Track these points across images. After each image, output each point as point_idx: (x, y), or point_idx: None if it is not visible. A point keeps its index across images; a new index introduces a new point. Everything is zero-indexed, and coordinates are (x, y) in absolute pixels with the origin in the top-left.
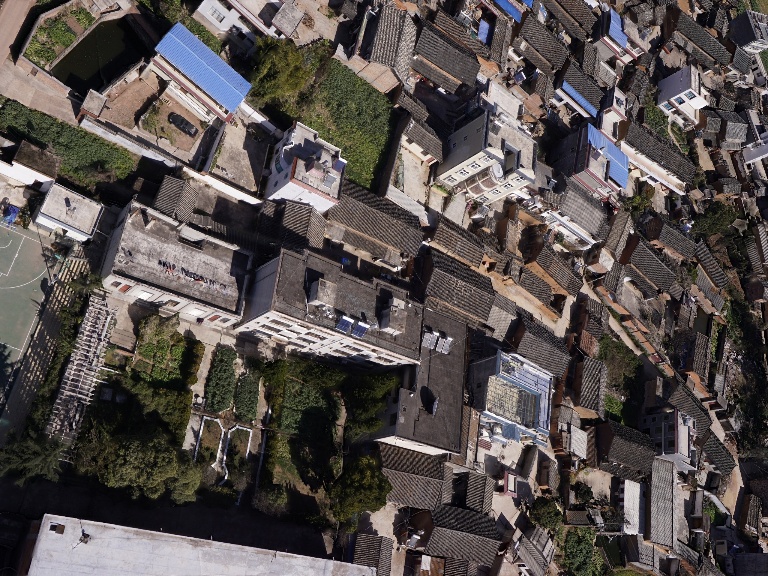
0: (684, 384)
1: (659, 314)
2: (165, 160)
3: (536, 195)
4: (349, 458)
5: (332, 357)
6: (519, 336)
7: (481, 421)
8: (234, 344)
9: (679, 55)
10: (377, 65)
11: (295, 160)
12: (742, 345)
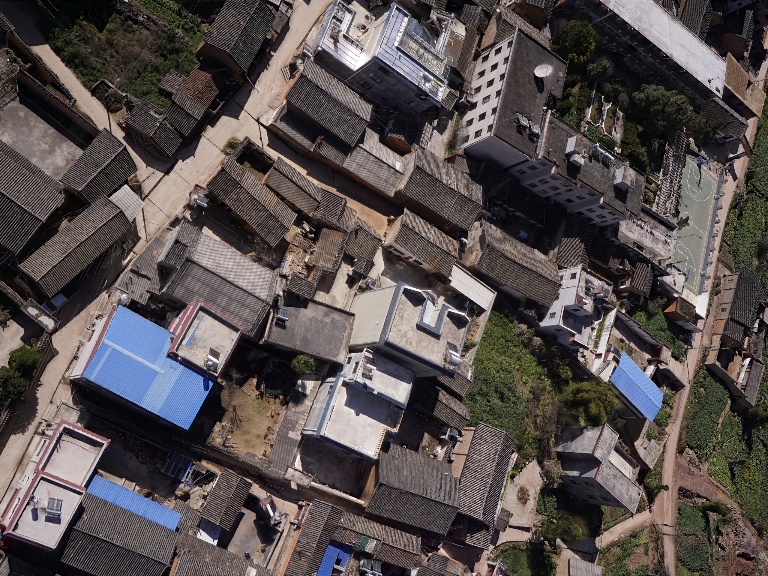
0: None
1: None
2: None
3: None
4: None
5: None
6: None
7: None
8: None
9: None
10: None
11: None
12: None
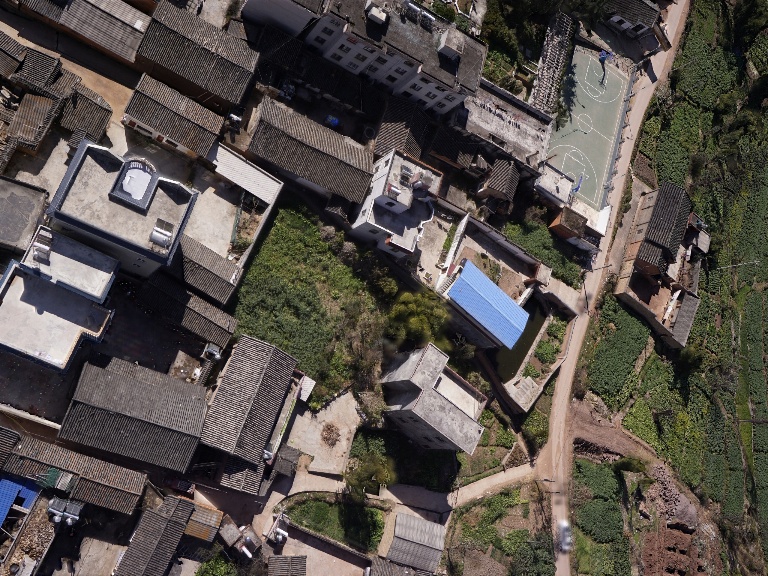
0: None
1: None
2: None
3: None
4: None
5: None
6: None
7: None
8: None
9: None
10: None
11: None
12: None
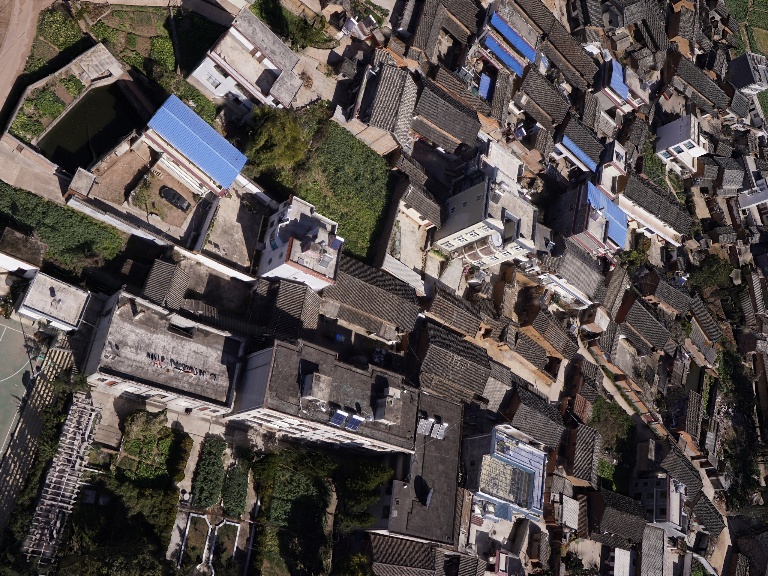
0: (676, 446)
1: (652, 370)
2: (155, 239)
3: (534, 258)
4: (339, 547)
5: (324, 442)
6: (514, 407)
7: (474, 499)
8: (223, 433)
9: (678, 99)
10: (376, 129)
11: (291, 240)
12: (733, 398)
